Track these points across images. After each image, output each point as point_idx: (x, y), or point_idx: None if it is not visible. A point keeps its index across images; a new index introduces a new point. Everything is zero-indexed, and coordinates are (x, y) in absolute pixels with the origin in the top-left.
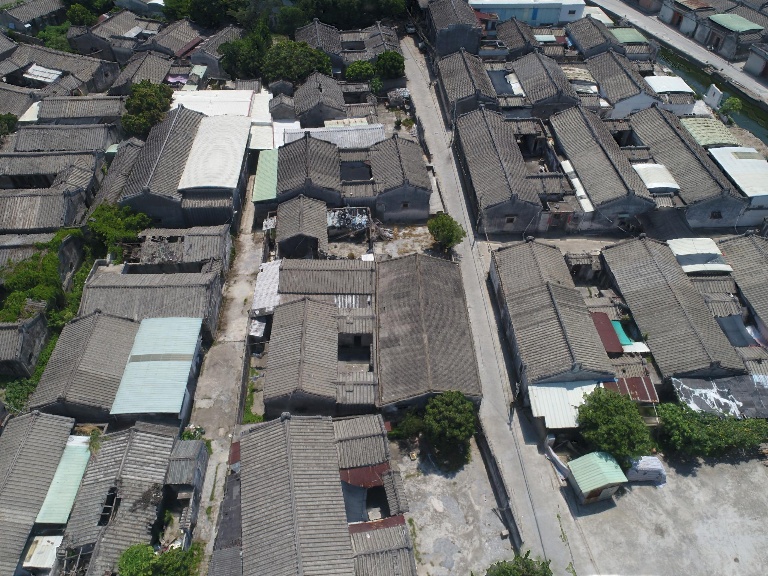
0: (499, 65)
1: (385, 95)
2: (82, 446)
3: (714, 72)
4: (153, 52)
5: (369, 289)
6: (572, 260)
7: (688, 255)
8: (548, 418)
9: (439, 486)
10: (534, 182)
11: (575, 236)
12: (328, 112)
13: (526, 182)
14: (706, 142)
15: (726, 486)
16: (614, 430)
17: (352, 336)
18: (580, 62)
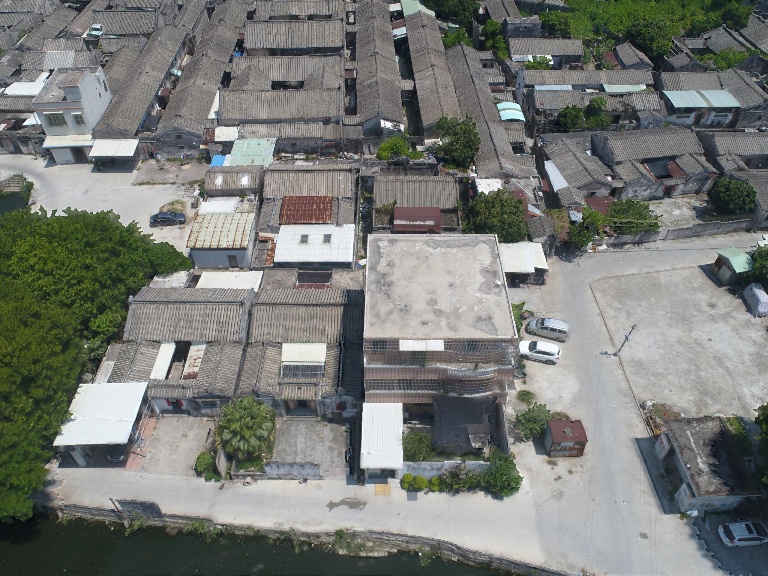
0: None
1: None
2: (642, 89)
3: None
4: None
5: None
6: None
7: None
8: (766, 241)
9: (689, 214)
10: None
11: None
12: None
13: None
14: None
15: None
16: None
17: None
18: None
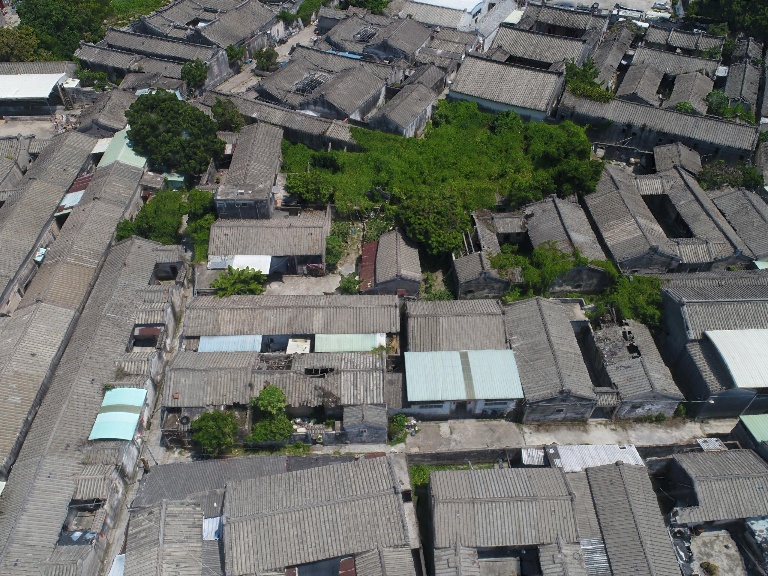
0: None
1: None
2: (377, 343)
3: None
4: None
5: None
6: None
7: None
8: None
9: None
10: None
11: None
12: None
13: None
14: None
15: None
16: None
17: None
18: None
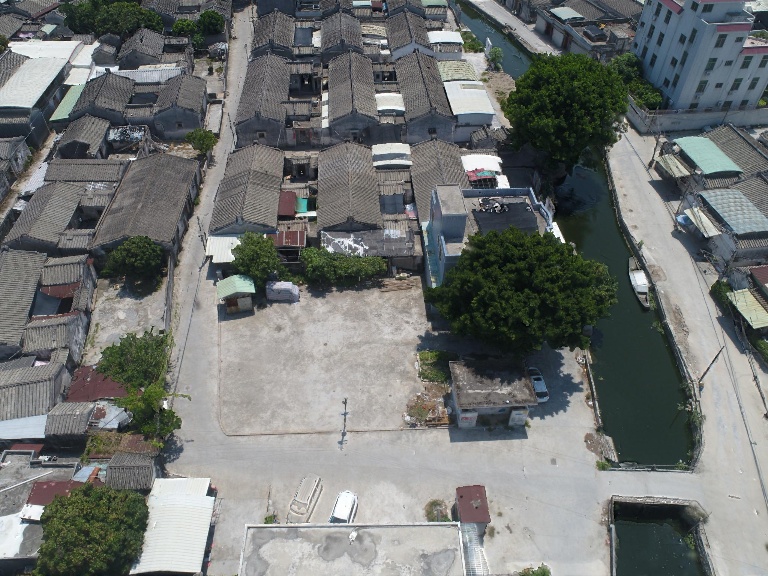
0: (308, 23)
1: (208, 48)
2: None
3: (509, 32)
4: (13, 14)
5: (116, 177)
6: (294, 160)
7: (382, 154)
8: (215, 256)
9: (128, 304)
10: (287, 106)
11: (318, 149)
12: (143, 58)
13: (279, 106)
14: (447, 78)
15: (344, 303)
16: (245, 255)
17: (95, 210)
18: (379, 21)
